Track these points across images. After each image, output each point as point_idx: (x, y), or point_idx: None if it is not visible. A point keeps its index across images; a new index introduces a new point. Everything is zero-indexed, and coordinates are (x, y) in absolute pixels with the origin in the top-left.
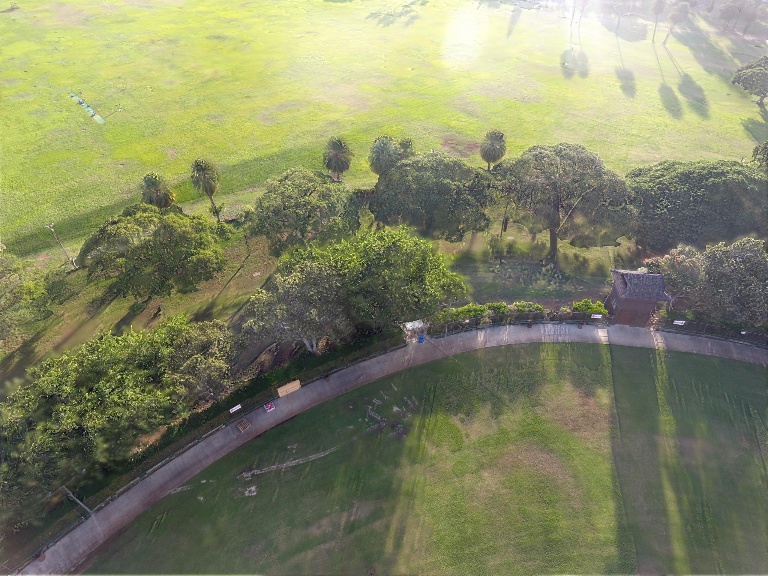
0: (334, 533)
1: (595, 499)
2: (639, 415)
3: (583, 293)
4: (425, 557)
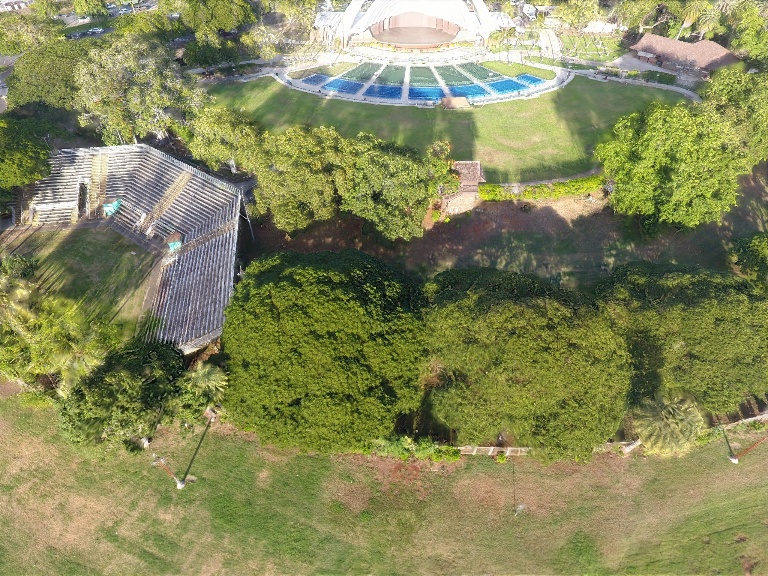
0: (597, 124)
1: (486, 135)
2: (459, 158)
3: (478, 245)
4: (556, 123)
